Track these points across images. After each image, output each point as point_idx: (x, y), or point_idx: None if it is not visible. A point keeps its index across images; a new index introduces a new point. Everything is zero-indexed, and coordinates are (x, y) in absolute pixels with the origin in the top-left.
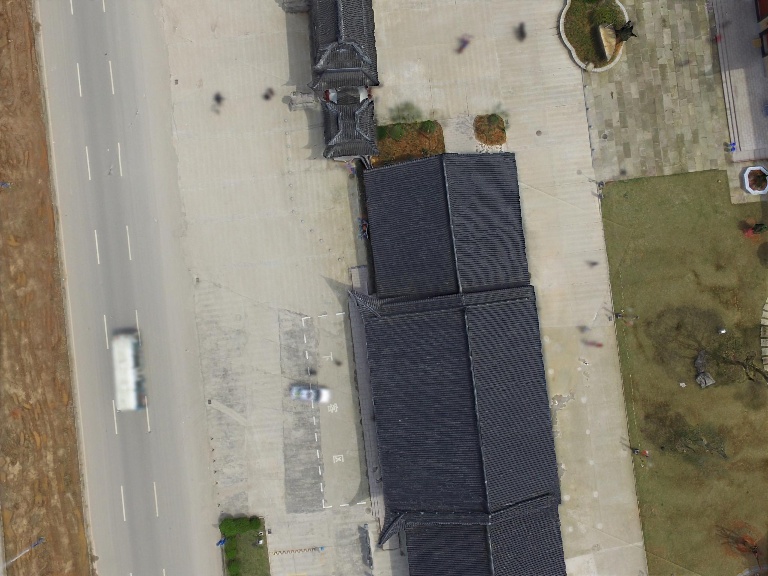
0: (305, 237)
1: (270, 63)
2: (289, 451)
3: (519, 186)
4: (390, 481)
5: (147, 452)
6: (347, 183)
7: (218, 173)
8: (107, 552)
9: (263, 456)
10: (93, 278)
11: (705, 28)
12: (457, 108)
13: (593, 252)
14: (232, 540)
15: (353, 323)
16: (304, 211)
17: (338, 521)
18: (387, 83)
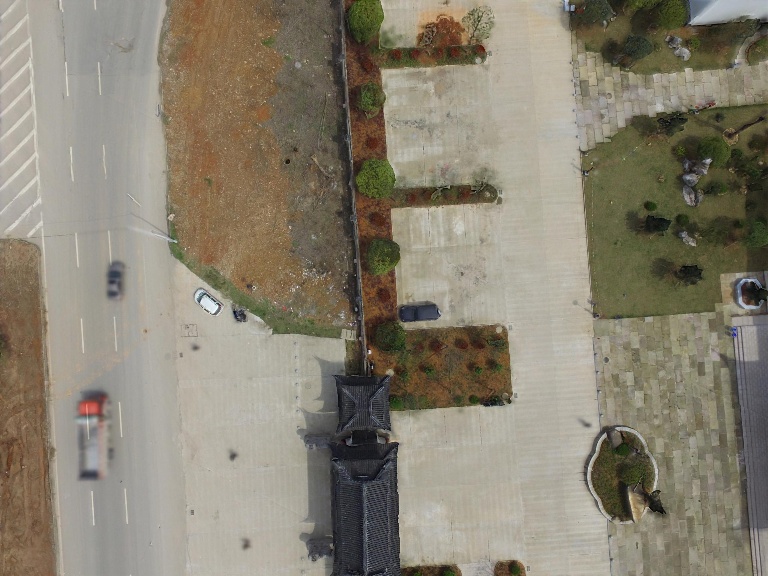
0: None
1: (289, 497)
2: None
3: None
4: None
5: None
6: None
7: None
8: None
9: None
10: None
11: (735, 480)
12: (478, 553)
13: None
14: None
15: None
16: None
17: None
18: (408, 523)
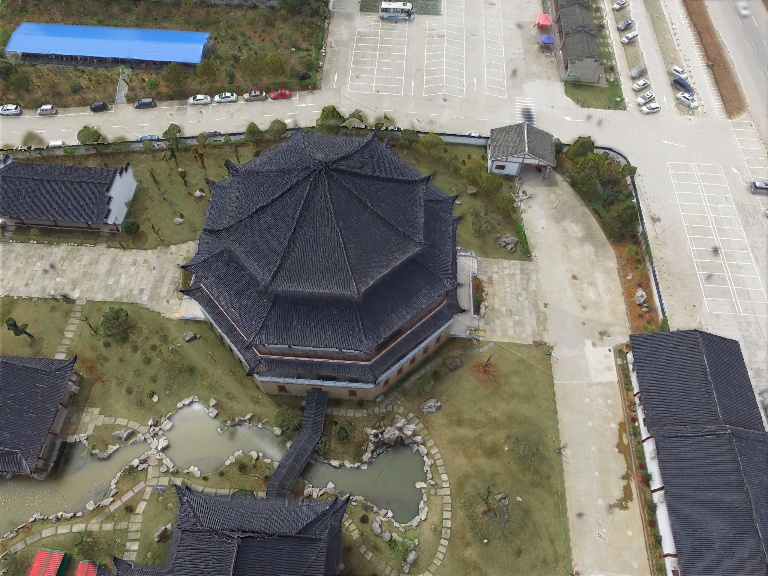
0: None
1: None
2: None
3: None
4: None
5: None
6: None
7: None
8: None
9: None
10: None
11: None
12: None
13: None
14: None
15: None
16: None
17: None
18: None
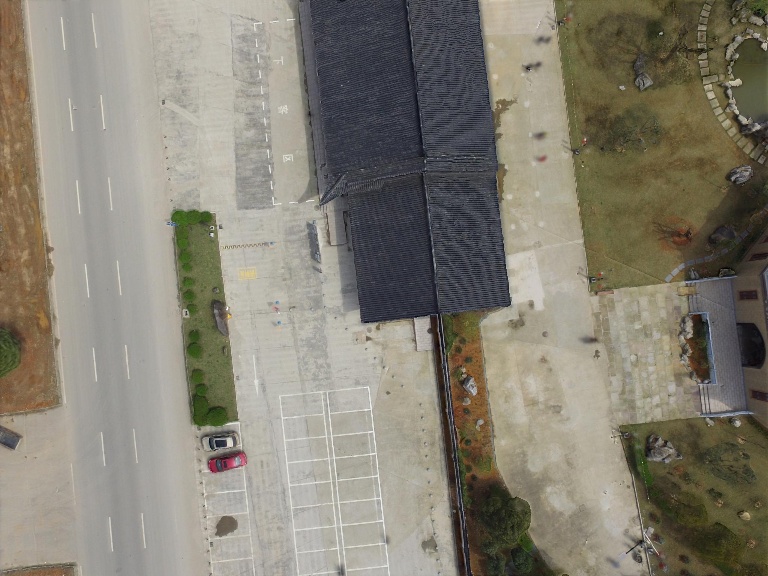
0: None
1: None
2: (240, 150)
3: None
4: (333, 147)
5: (102, 148)
6: None
7: None
8: (62, 243)
9: (215, 154)
10: None
11: None
12: None
13: None
14: (183, 228)
15: (303, 27)
16: None
17: (287, 218)
18: None
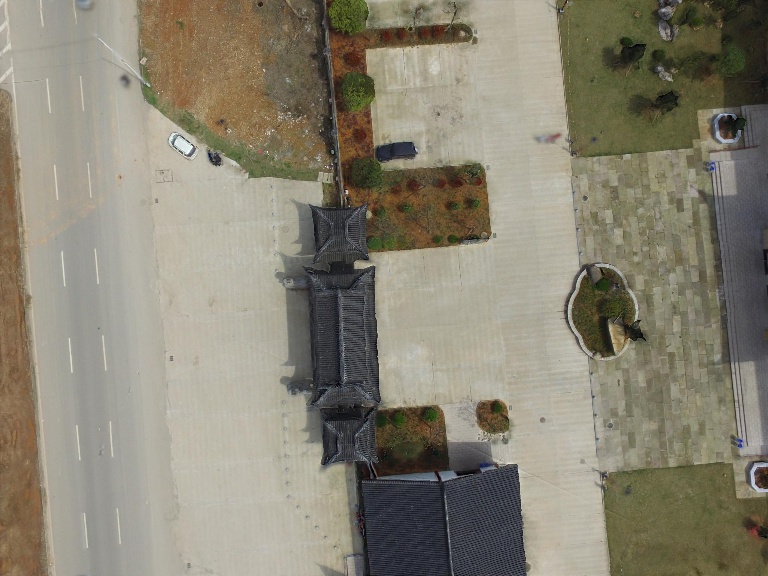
0: (300, 523)
1: (269, 341)
2: None
3: (521, 474)
4: None
5: None
6: (345, 468)
7: (212, 455)
8: None
9: None
10: (81, 563)
11: (716, 316)
12: (460, 393)
13: (594, 544)
14: None
15: None
16: (300, 496)
17: None
18: (389, 365)
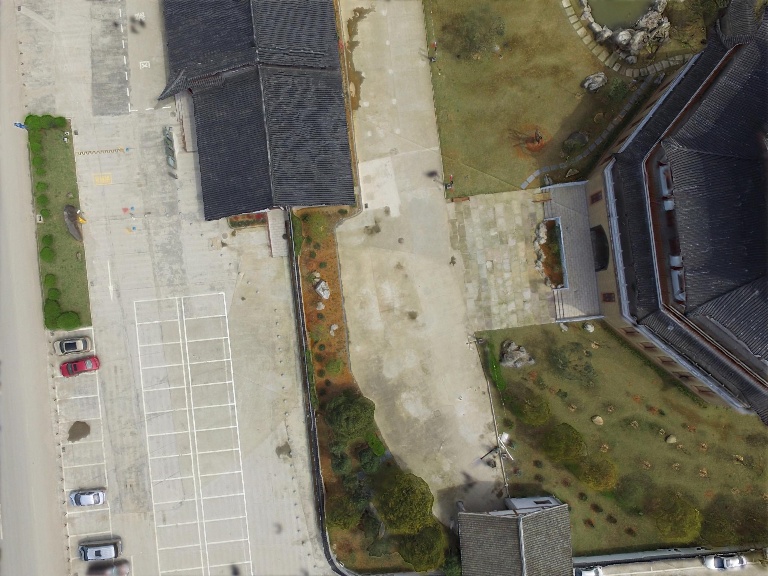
0: None
1: None
2: (96, 57)
3: None
4: (174, 43)
5: None
6: None
7: None
8: None
9: (71, 60)
10: None
11: None
12: None
13: None
14: (35, 132)
15: None
16: None
17: (143, 124)
18: None
